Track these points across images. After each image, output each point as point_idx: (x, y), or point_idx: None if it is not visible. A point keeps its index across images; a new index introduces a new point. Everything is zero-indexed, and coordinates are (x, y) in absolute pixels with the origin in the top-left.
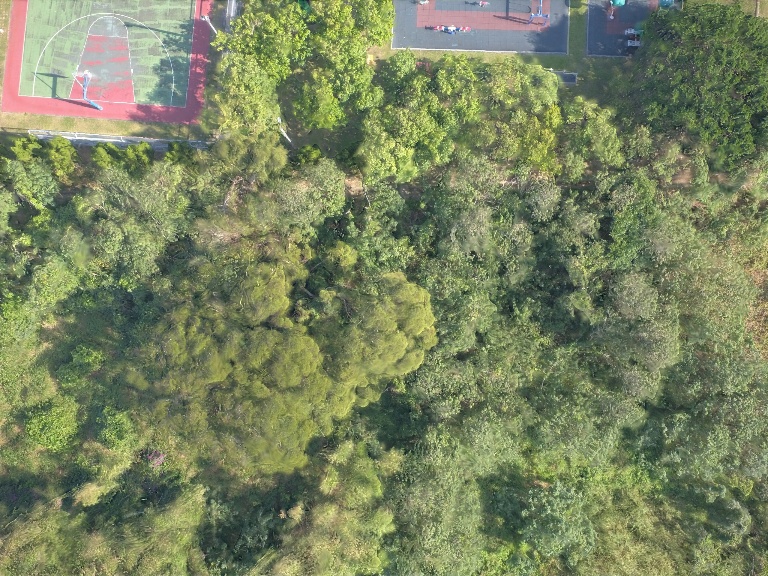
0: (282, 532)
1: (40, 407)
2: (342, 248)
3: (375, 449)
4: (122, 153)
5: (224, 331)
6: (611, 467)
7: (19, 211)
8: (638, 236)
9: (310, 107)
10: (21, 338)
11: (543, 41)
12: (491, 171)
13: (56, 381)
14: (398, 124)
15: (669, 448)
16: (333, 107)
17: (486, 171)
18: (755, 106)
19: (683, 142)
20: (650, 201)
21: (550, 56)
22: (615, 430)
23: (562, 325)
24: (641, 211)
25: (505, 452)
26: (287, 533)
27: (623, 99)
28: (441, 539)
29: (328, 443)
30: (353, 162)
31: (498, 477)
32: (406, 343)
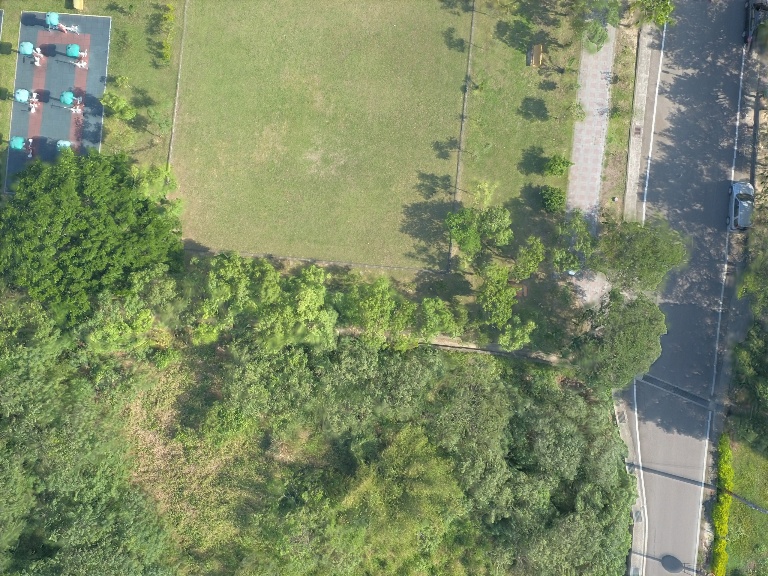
0: None
1: None
2: None
3: None
4: None
5: None
6: None
7: None
8: None
9: None
10: None
11: None
12: None
13: None
14: None
15: None
16: None
17: None
18: (89, 265)
19: None
20: None
21: None
22: None
23: None
24: None
25: None
26: None
27: None
28: None
29: None
30: None
31: None
32: None
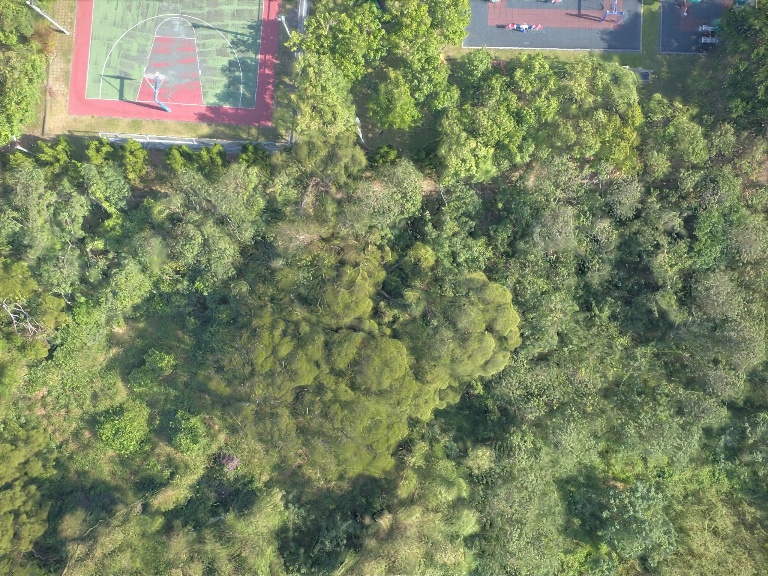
0: (362, 536)
1: (111, 412)
2: (423, 249)
3: (453, 451)
4: (197, 155)
5: (311, 334)
6: (688, 467)
7: (89, 215)
8: (722, 234)
9: (387, 107)
10: (91, 342)
11: (616, 38)
12: (573, 170)
13: (127, 385)
14: (478, 123)
15: (751, 447)
16: (410, 107)
17: (568, 170)
18: None
19: (767, 139)
20: (735, 199)
21: (623, 53)
22: (699, 430)
23: (640, 324)
24: (725, 209)
25: (586, 453)
26: (370, 537)
27: (703, 96)
28: (525, 541)
29: (404, 445)
30: (430, 162)
31: (574, 478)
32: (493, 344)
